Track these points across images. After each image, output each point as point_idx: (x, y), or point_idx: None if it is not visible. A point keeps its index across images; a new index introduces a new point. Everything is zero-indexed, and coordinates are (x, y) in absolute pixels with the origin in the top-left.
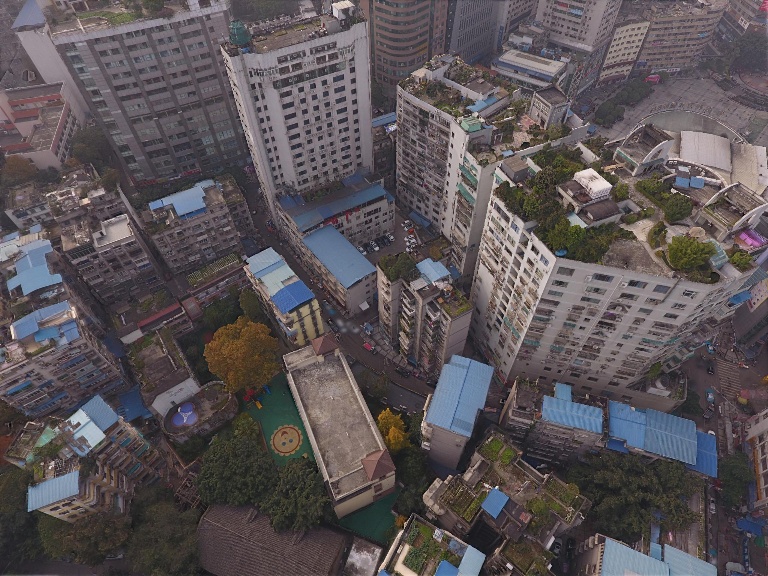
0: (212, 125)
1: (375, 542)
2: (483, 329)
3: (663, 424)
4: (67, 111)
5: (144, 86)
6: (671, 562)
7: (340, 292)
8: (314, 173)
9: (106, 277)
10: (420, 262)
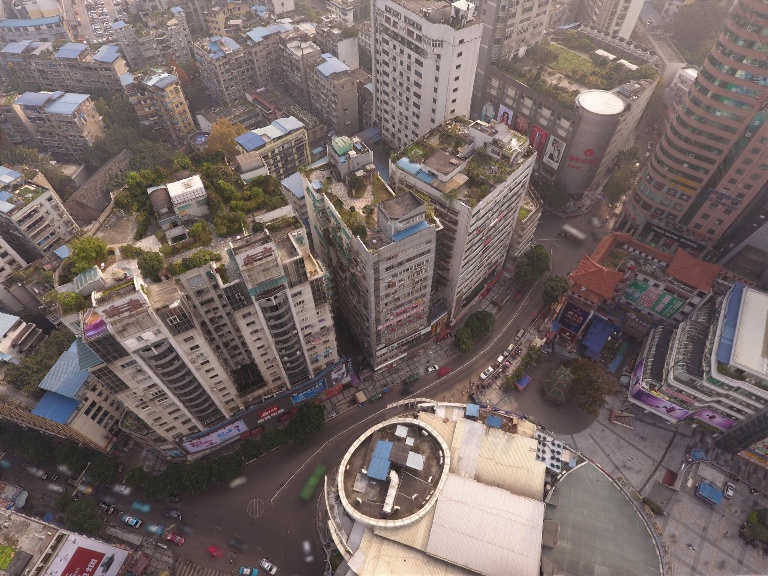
0: None
1: None
2: None
3: None
4: None
5: None
6: None
7: None
8: (393, 130)
9: None
10: None
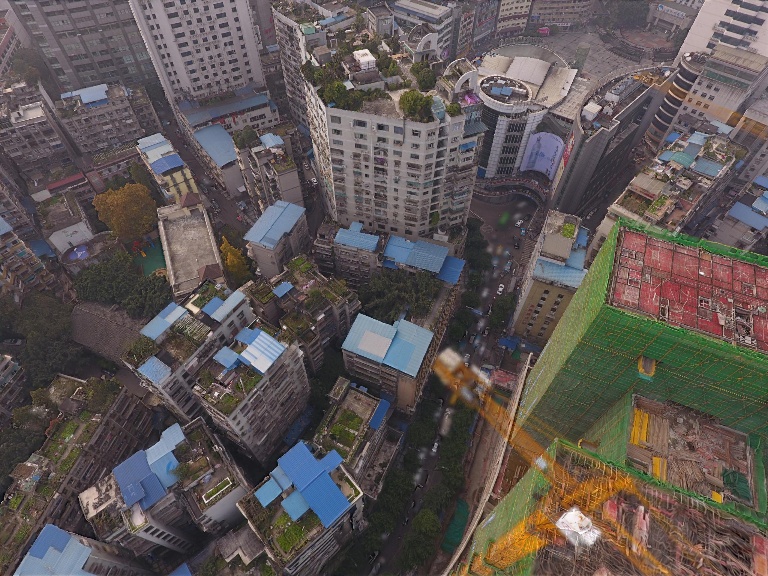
0: (131, 45)
1: None
2: (325, 200)
3: (425, 249)
4: (11, 34)
5: (66, 4)
6: (401, 328)
7: (219, 174)
8: (207, 81)
9: (24, 152)
10: (263, 135)
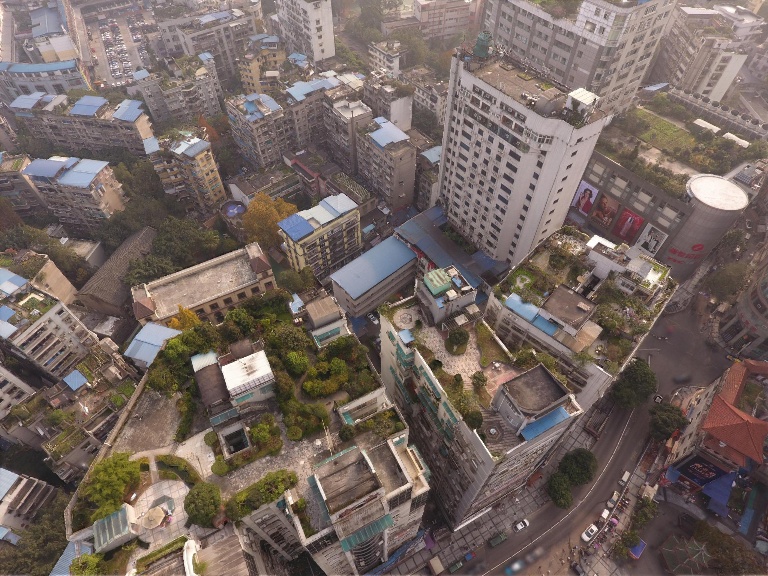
0: None
1: (126, 339)
2: None
3: None
4: None
5: None
6: None
7: None
8: (464, 216)
9: None
10: (298, 296)
